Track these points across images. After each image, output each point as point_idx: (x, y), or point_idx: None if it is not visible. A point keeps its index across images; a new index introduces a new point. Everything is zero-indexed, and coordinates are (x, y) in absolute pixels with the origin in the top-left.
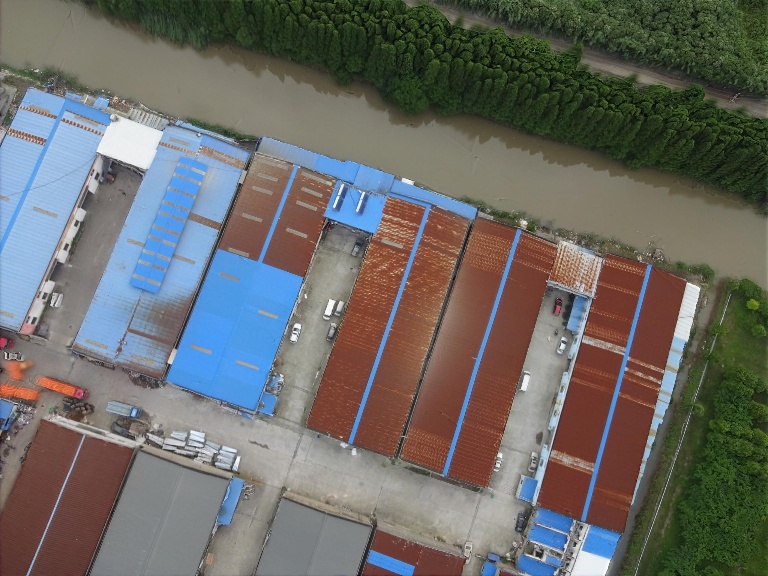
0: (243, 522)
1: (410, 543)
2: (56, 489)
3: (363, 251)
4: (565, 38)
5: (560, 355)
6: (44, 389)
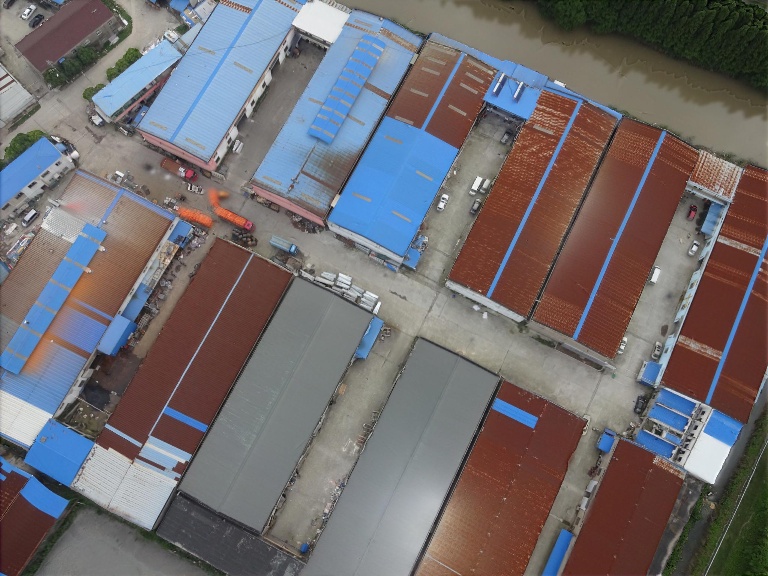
0: (376, 362)
1: (535, 396)
2: (223, 296)
3: (511, 141)
4: None
5: (691, 257)
6: (217, 220)
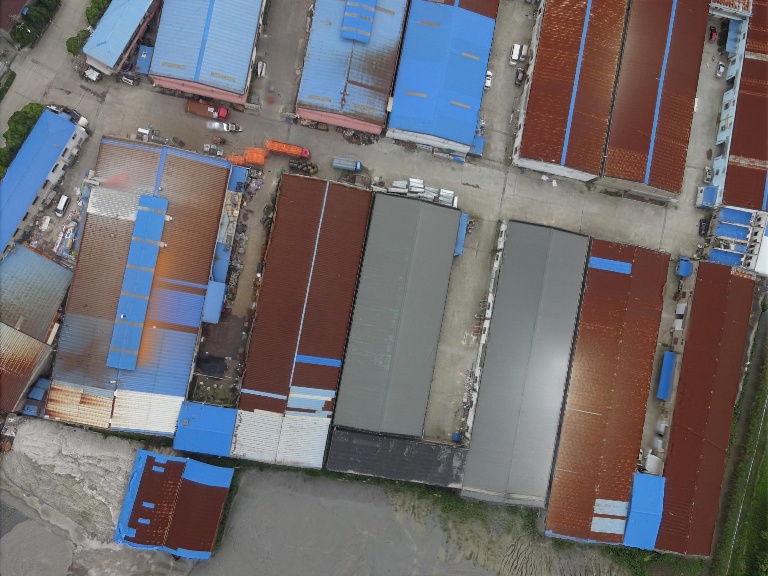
0: (469, 255)
1: (624, 245)
2: (313, 233)
3: None
4: None
5: (719, 78)
6: (268, 155)
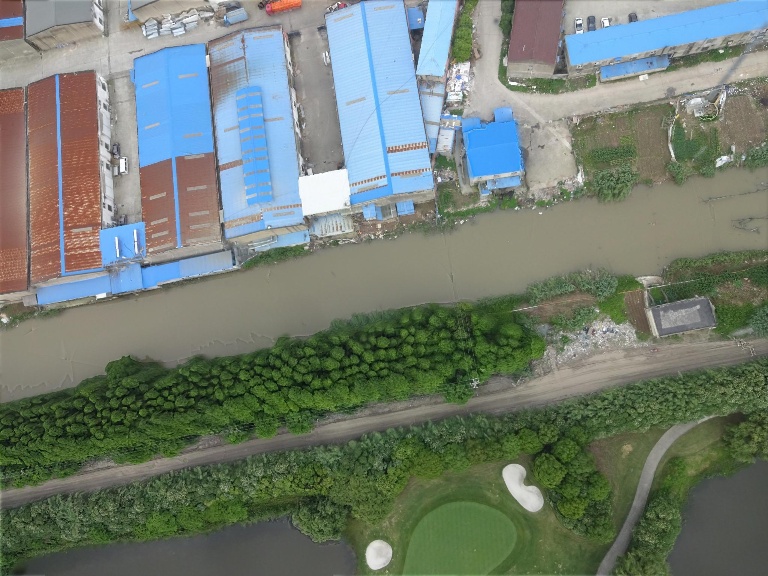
0: (125, 2)
1: None
2: None
3: (119, 224)
4: None
5: None
6: None
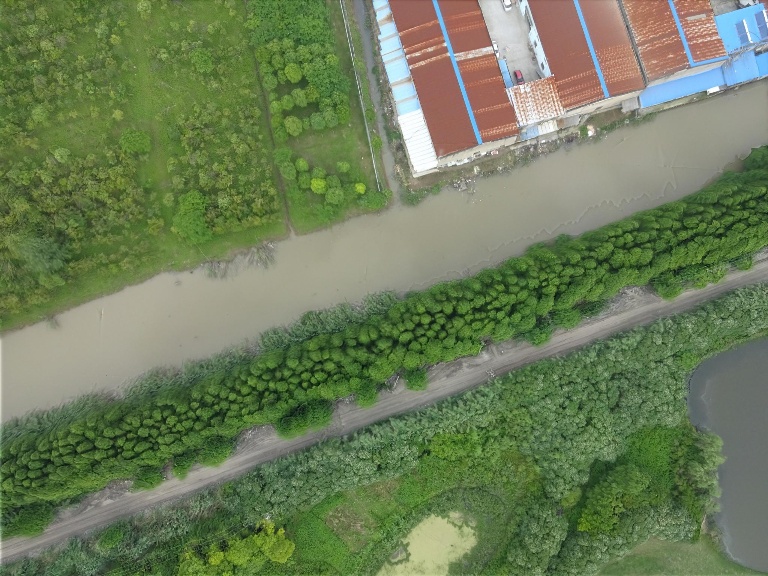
0: None
1: None
2: None
3: None
4: None
5: None
6: None
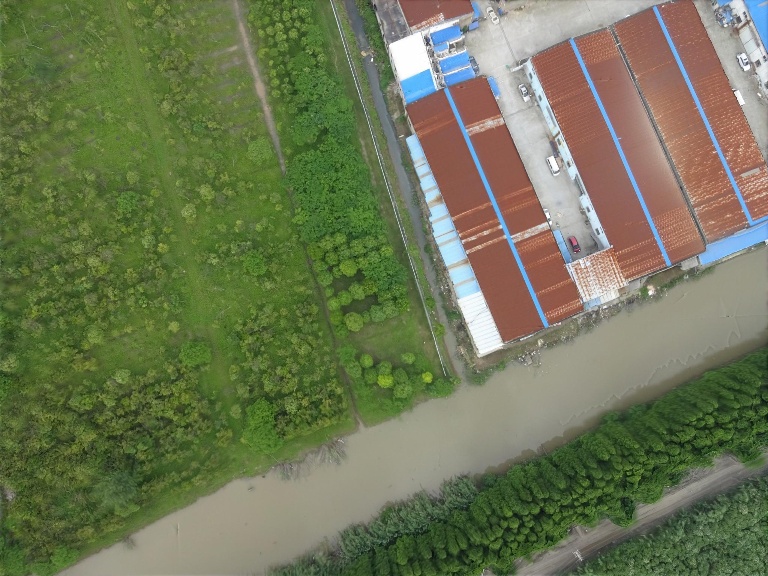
0: None
1: None
2: None
3: None
4: (761, 475)
5: None
6: None
